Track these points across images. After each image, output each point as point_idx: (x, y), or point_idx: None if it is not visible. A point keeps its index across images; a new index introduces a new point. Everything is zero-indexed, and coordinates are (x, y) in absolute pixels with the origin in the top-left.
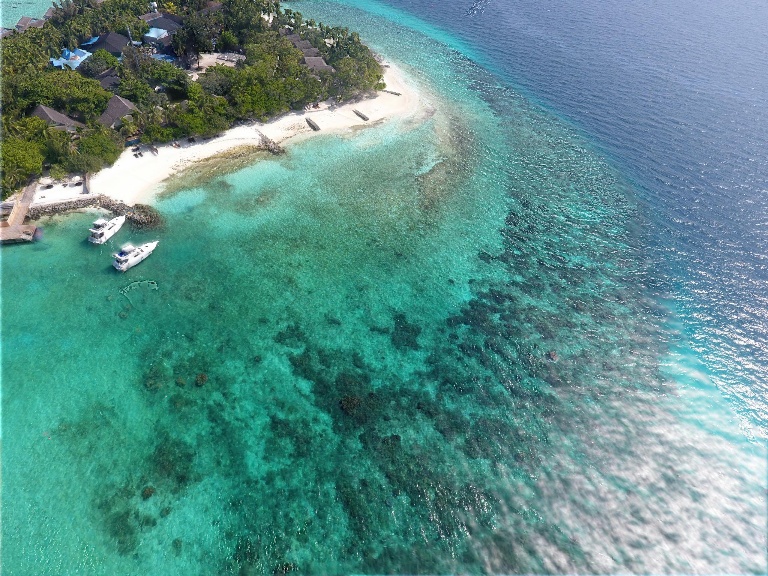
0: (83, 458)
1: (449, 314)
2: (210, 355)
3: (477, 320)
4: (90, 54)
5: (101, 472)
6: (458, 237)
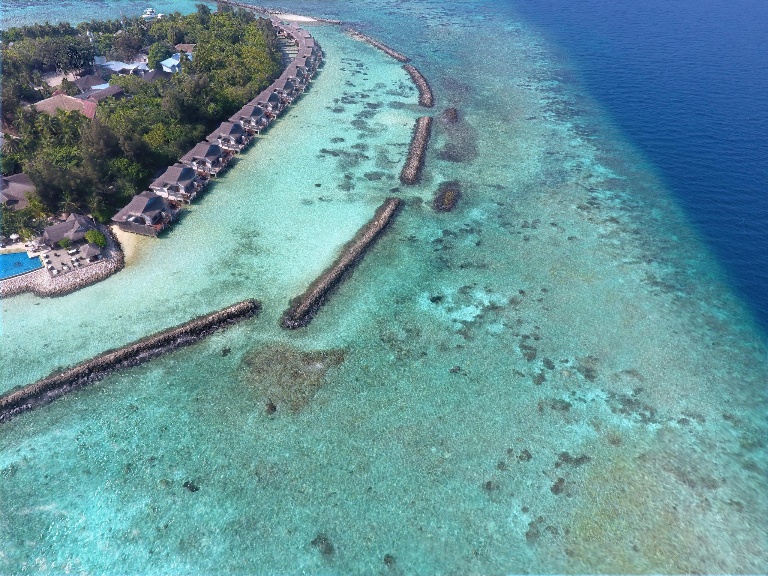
0: (165, 1)
1: (45, 5)
2: (131, 6)
3: (36, 3)
4: (170, 61)
5: (161, 0)
6: (8, 14)
